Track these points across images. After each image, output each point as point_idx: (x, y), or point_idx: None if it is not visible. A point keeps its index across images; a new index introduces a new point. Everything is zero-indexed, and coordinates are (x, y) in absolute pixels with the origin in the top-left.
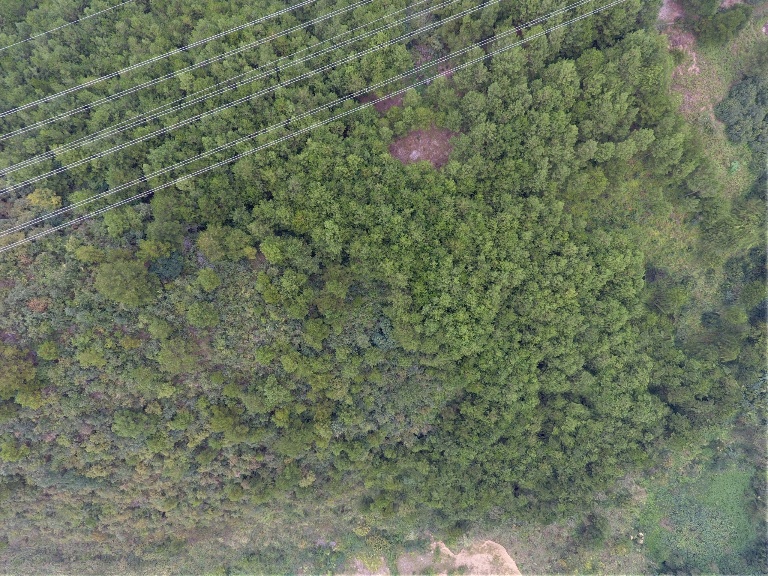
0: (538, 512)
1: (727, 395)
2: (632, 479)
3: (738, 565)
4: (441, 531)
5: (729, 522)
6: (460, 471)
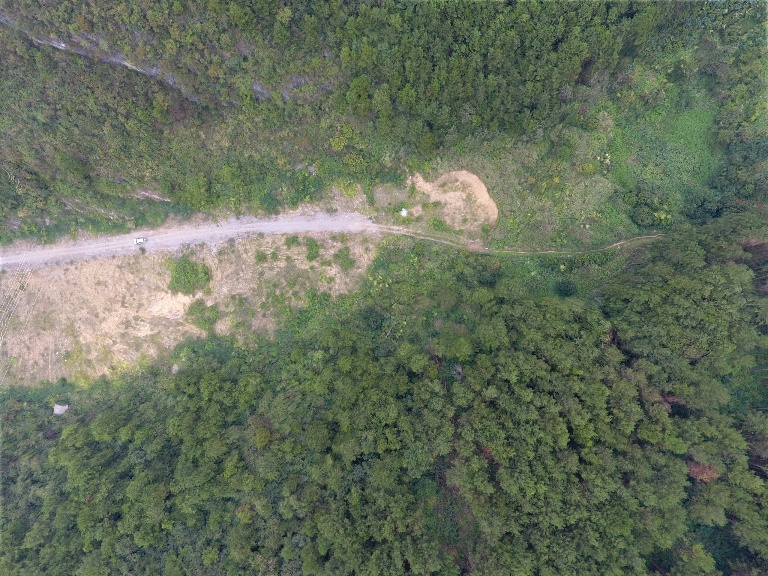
0: (507, 95)
1: None
2: (600, 106)
3: (700, 191)
4: (416, 155)
5: (693, 157)
6: (431, 26)
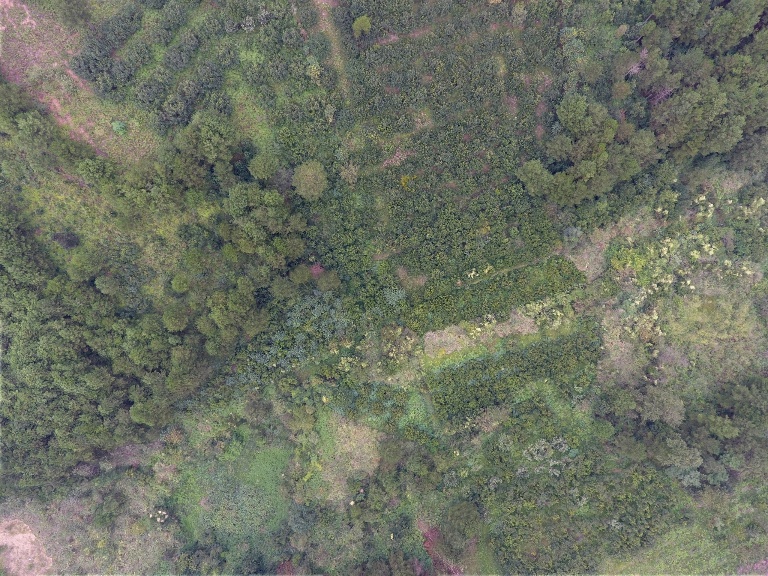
0: (5, 487)
1: (173, 366)
2: (156, 456)
3: (265, 544)
4: None
5: (267, 501)
6: None
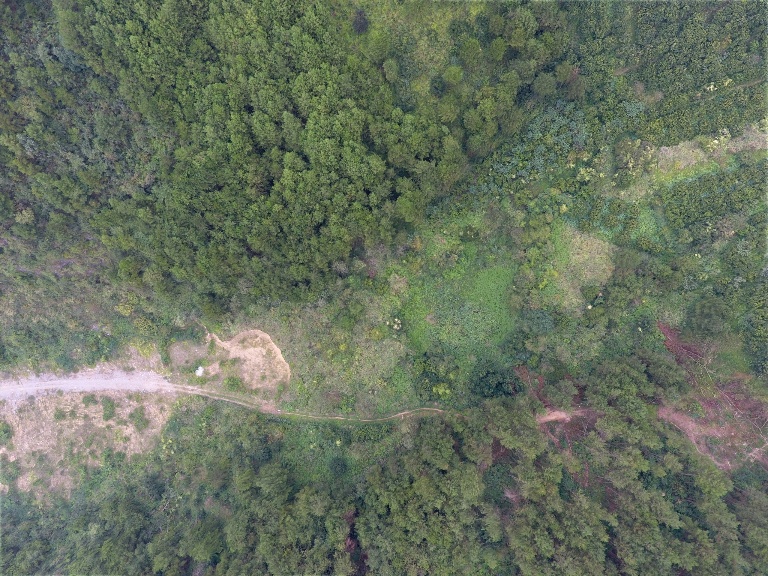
0: (273, 276)
1: (445, 154)
2: (391, 268)
3: (494, 354)
4: (208, 317)
5: (491, 317)
6: (180, 219)
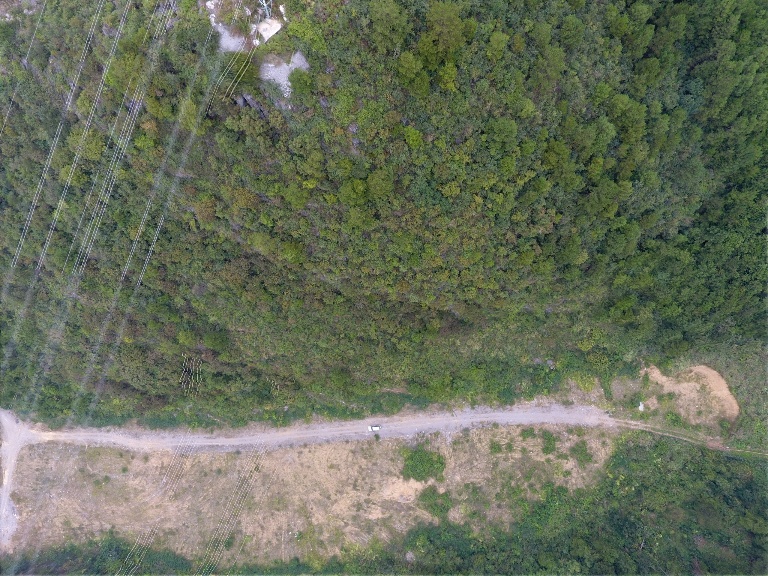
0: None
1: None
2: None
3: None
4: (658, 353)
5: None
6: (721, 262)
